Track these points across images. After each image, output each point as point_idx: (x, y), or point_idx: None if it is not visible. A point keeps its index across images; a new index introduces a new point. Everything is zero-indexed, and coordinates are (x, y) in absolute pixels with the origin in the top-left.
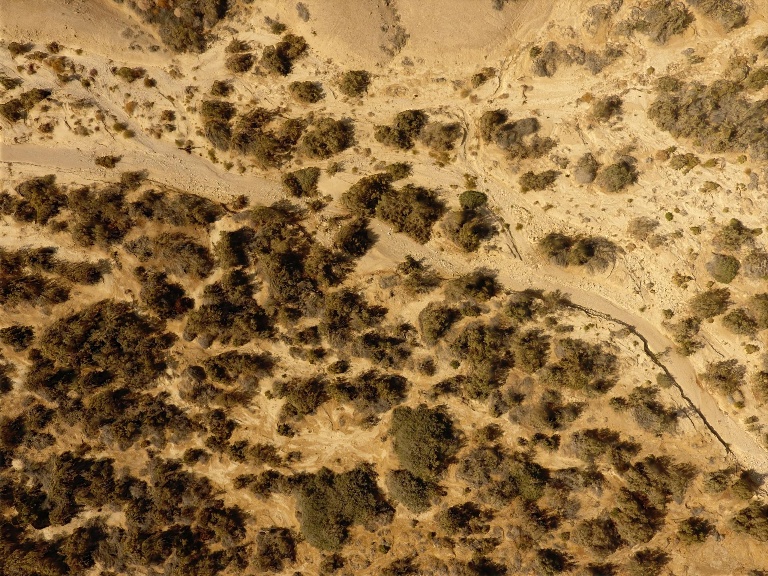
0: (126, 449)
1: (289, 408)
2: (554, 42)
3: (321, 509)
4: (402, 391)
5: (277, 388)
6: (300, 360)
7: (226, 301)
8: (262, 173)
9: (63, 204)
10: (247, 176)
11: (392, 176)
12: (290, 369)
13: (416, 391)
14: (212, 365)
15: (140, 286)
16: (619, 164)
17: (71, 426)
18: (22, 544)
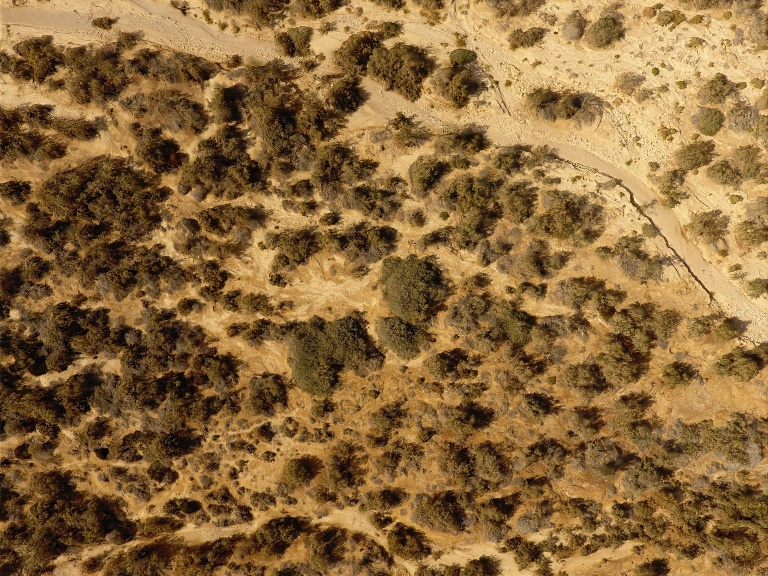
0: (121, 299)
1: (281, 257)
2: None
3: (312, 352)
4: (392, 241)
5: (270, 237)
6: (292, 212)
7: (220, 155)
8: (256, 33)
9: (60, 62)
10: (241, 37)
11: (383, 33)
12: (282, 221)
13: (406, 241)
14: (206, 216)
15: (136, 142)
16: (606, 17)
17: (67, 277)
18: (19, 390)
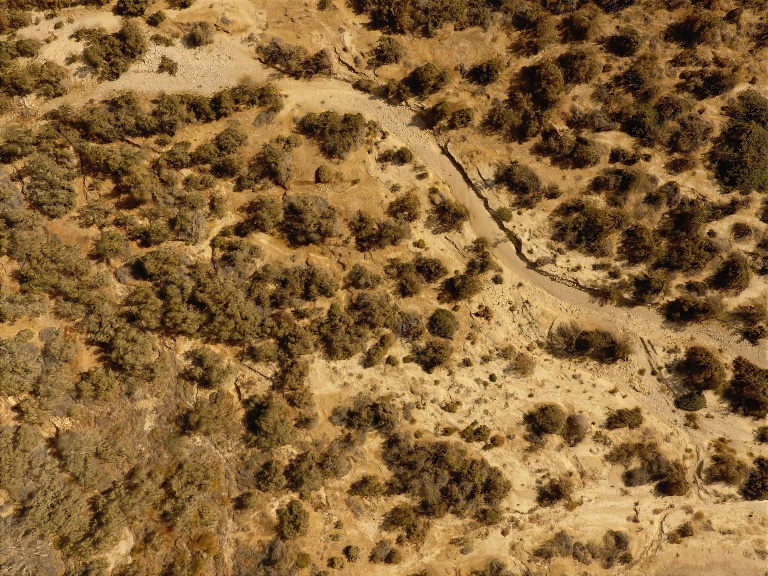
0: None
1: None
2: (605, 569)
3: None
4: (767, 208)
5: None
6: None
7: None
8: None
9: None
10: None
11: None
12: None
13: (752, 208)
14: None
15: None
16: None
17: None
18: None
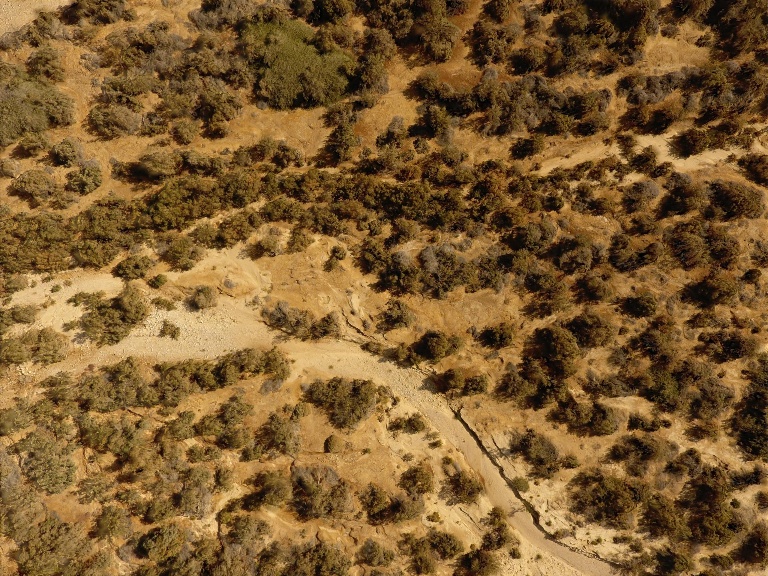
0: None
1: None
2: None
3: None
4: None
5: None
6: None
7: None
8: None
9: None
10: None
11: None
12: None
13: None
14: None
15: None
16: None
17: None
18: None
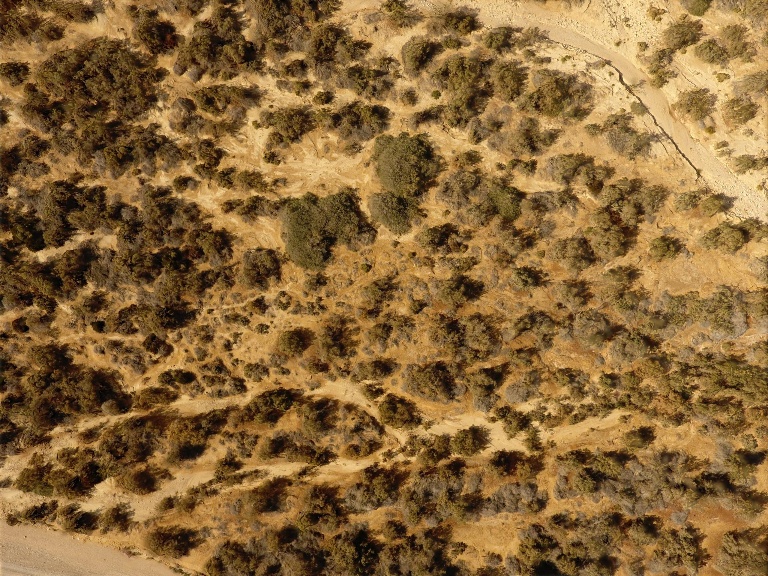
0: (118, 177)
1: (275, 134)
2: None
3: (305, 224)
4: (385, 119)
5: (264, 114)
6: (286, 92)
7: (215, 35)
8: None
9: None
10: None
11: None
12: (277, 101)
13: (398, 120)
14: (201, 95)
15: (132, 24)
16: None
17: (65, 156)
18: None
